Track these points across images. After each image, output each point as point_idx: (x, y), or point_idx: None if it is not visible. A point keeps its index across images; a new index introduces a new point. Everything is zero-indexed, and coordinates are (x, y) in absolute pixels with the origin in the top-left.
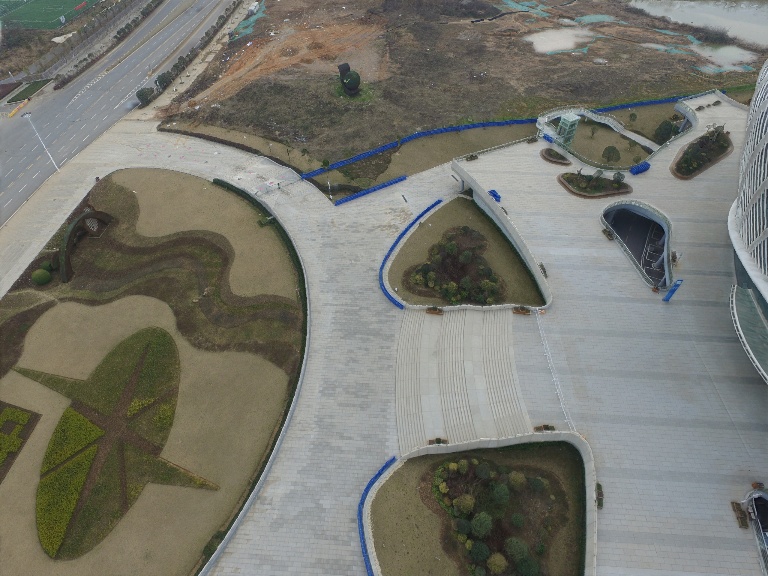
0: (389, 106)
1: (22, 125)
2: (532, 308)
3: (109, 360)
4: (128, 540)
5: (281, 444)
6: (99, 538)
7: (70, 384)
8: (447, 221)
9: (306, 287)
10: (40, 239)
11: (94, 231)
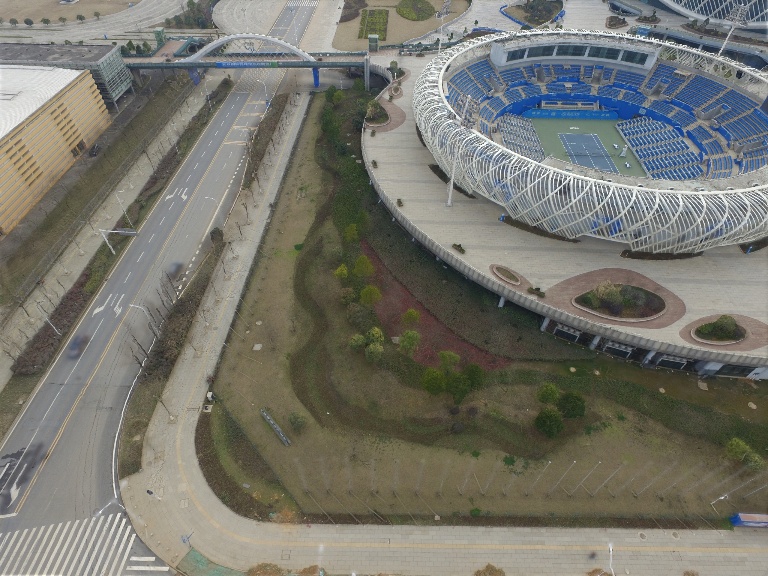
0: None
1: None
2: None
3: (402, 2)
4: None
5: (472, 5)
6: None
7: None
8: None
9: None
10: None
11: None
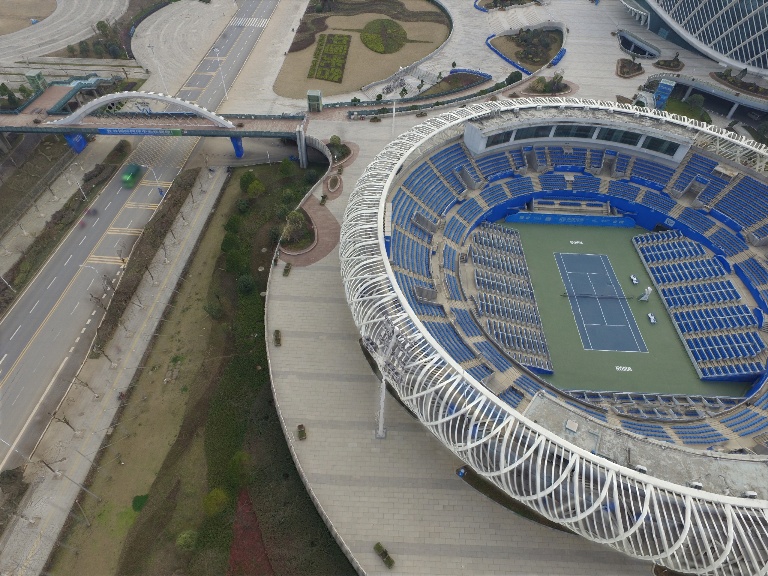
0: None
1: None
2: (542, 3)
3: (369, 25)
4: (407, 50)
5: None
6: (397, 50)
7: (357, 29)
8: None
9: None
10: (304, 2)
11: None
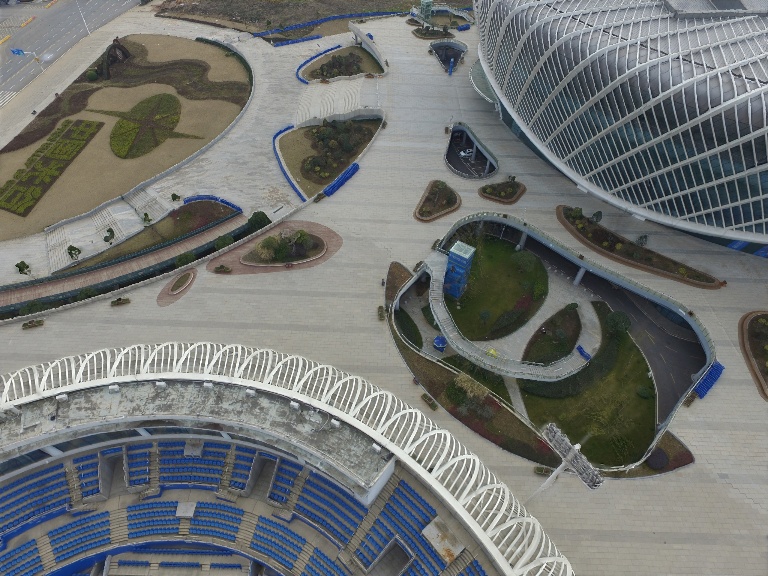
0: (317, 3)
1: (57, 12)
2: (375, 75)
3: (140, 104)
4: (160, 153)
5: (236, 123)
6: (145, 152)
7: (119, 112)
8: (342, 53)
9: None
10: (85, 64)
11: (120, 59)
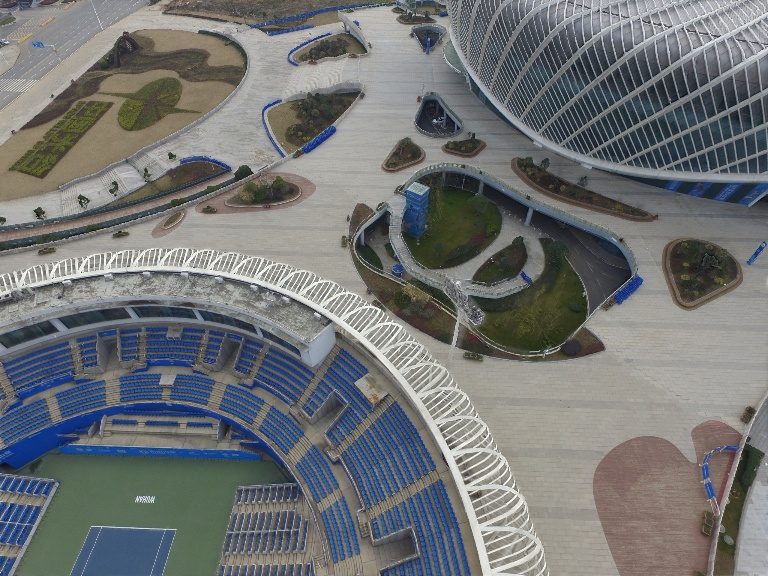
0: None
1: (74, 13)
2: (358, 55)
3: (146, 87)
4: (162, 125)
5: (230, 99)
6: (149, 125)
7: (127, 94)
8: (331, 40)
9: (248, 59)
10: (98, 55)
11: (130, 50)
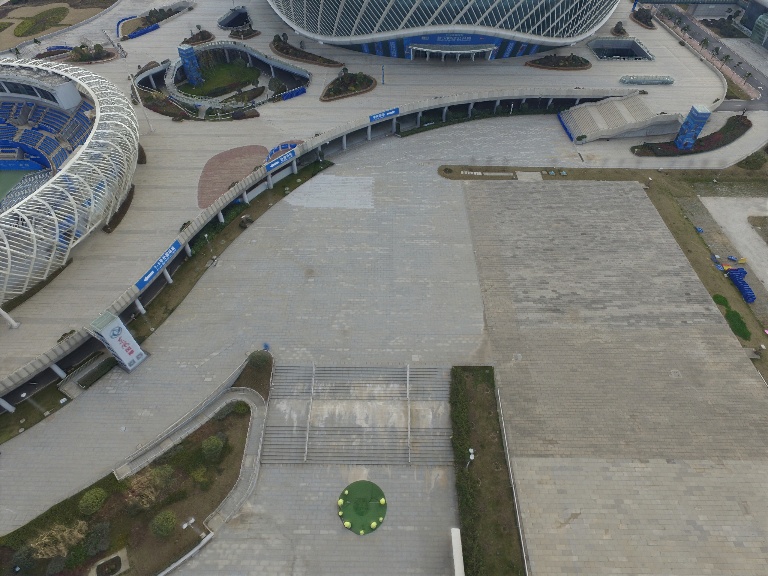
0: None
1: None
2: None
3: (42, 13)
4: (44, 33)
5: None
6: (35, 33)
7: None
8: None
9: None
10: None
11: None
